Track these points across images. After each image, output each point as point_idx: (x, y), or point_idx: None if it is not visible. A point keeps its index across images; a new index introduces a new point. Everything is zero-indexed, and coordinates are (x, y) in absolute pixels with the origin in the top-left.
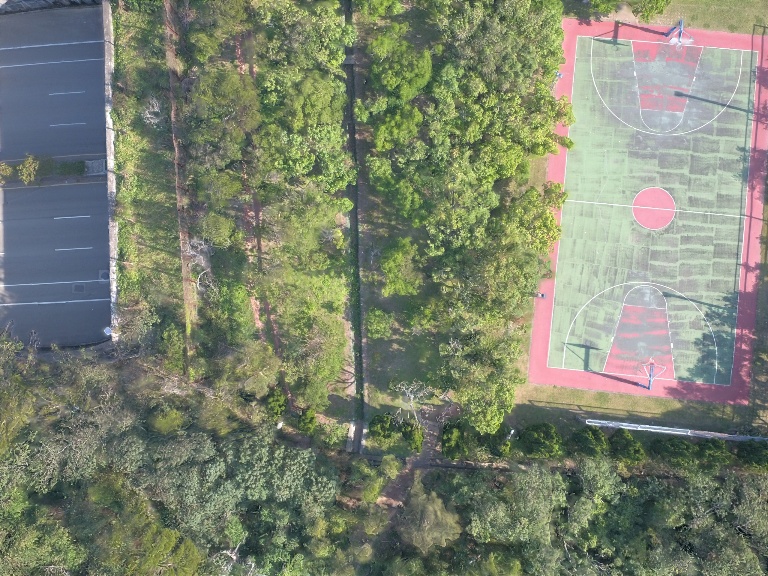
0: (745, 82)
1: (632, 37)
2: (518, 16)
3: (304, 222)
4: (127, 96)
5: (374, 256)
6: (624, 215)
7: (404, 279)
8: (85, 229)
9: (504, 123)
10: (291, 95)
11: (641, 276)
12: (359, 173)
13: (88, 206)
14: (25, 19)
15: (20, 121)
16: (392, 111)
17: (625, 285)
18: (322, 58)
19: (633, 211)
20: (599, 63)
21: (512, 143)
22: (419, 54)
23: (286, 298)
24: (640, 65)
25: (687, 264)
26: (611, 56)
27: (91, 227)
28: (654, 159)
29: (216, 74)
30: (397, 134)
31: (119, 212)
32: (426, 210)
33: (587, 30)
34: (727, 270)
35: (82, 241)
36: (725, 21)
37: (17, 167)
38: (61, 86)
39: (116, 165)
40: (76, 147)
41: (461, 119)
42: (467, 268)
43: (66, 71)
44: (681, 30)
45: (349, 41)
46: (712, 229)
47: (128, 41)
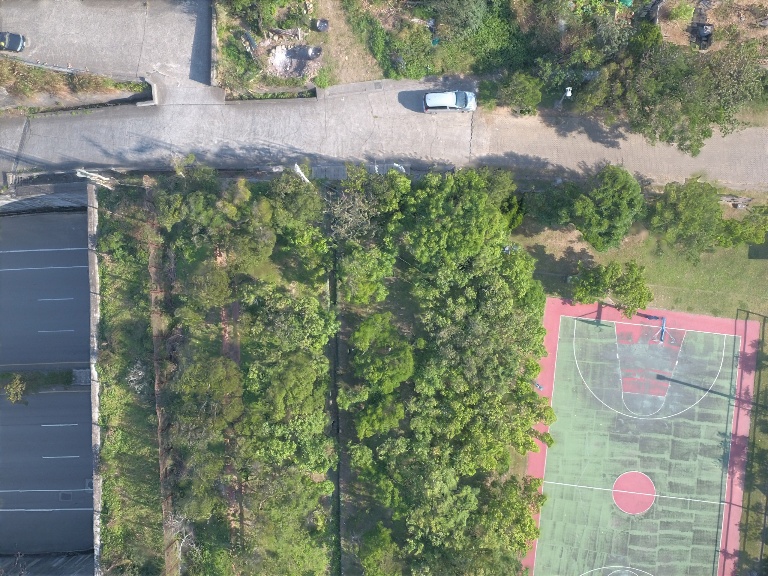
0: (727, 367)
1: (615, 318)
2: (500, 316)
3: (284, 515)
4: (112, 352)
5: (354, 540)
6: (604, 499)
7: (383, 573)
8: (72, 437)
9: (485, 420)
10: (273, 386)
11: (620, 560)
12: (341, 442)
13: (75, 414)
14: (14, 223)
15: (8, 326)
16: (374, 397)
17: (604, 569)
18: (304, 345)
19: (613, 495)
20: (582, 344)
21: (492, 440)
22: (402, 340)
23: (267, 570)
24: (623, 347)
25: (666, 550)
26: (594, 337)
27: (78, 435)
28: (635, 443)
29: (200, 336)
30: (378, 427)
31: (103, 470)
32: (406, 503)
33: (570, 310)
34: (706, 557)
35: (69, 449)
36: (709, 305)
37: (4, 387)
38: (49, 292)
39: (101, 417)
40: (64, 354)
41: (442, 413)
42: (445, 569)
43: (54, 277)
44: (663, 329)
45: (331, 332)
46: (691, 515)
47: (113, 292)
